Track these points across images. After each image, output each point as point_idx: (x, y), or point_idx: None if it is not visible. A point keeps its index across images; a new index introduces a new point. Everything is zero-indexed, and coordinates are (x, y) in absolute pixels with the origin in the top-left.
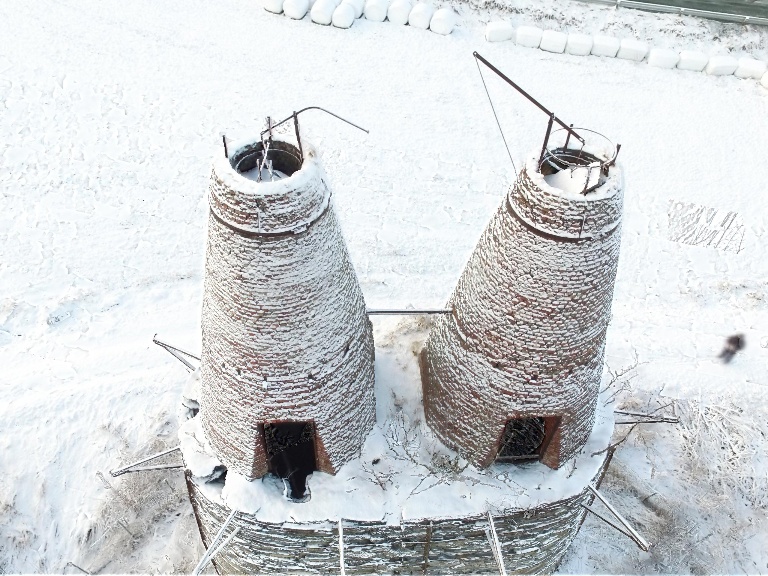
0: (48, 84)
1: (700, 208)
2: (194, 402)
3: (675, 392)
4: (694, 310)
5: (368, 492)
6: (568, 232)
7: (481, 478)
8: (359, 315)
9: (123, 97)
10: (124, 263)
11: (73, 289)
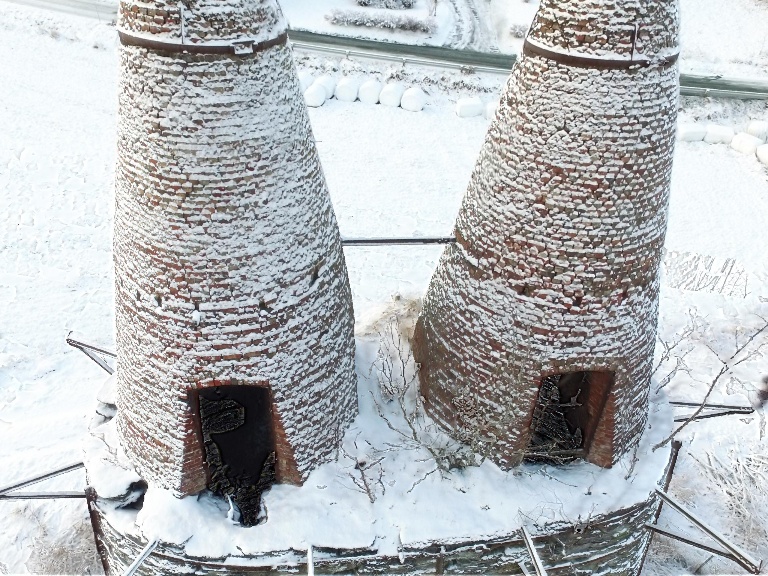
0: (4, 156)
1: (696, 256)
2: (112, 408)
3: (708, 442)
4: (710, 355)
5: (349, 506)
6: (615, 52)
7: (508, 481)
8: (331, 233)
9: (83, 167)
10: (66, 326)
11: (3, 356)
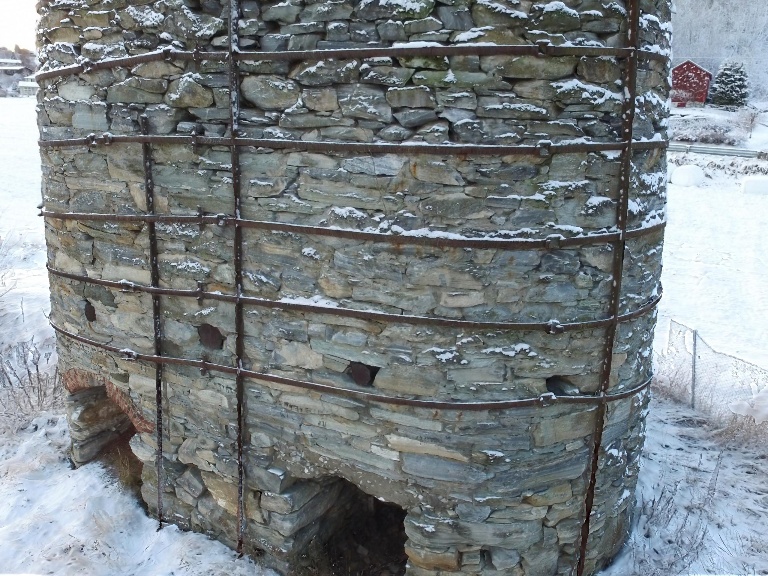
0: None
1: None
2: None
3: None
4: None
5: None
6: None
7: None
8: None
9: None
10: None
11: None
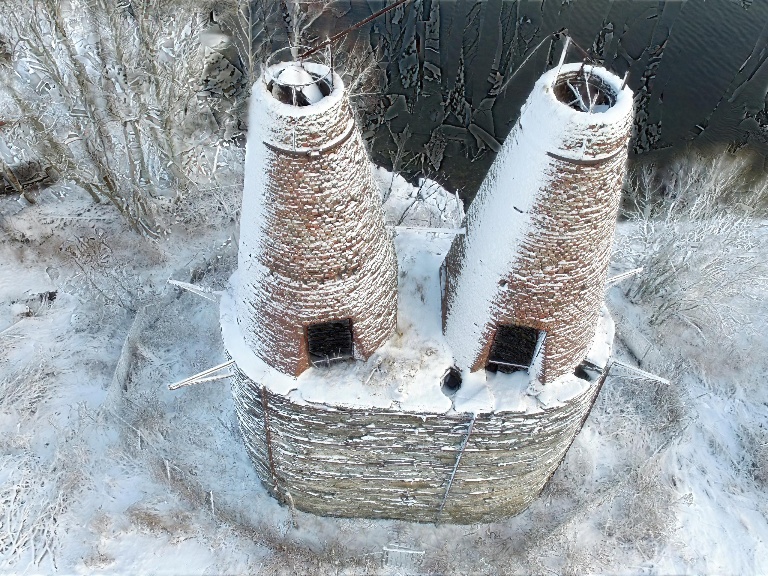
0: None
1: None
2: None
3: None
4: None
5: None
6: None
7: None
8: None
9: None
10: None
11: None
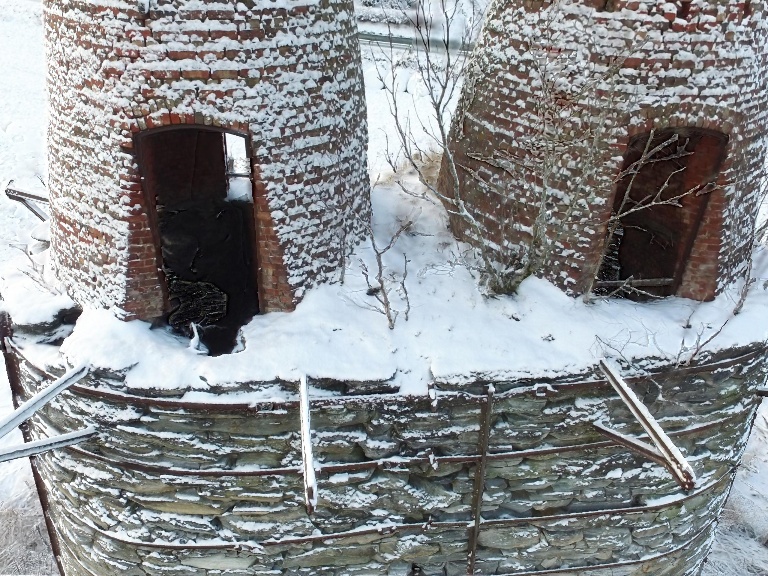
0: None
1: None
2: None
3: (763, 405)
4: None
5: (360, 332)
6: None
7: (577, 308)
8: None
9: None
10: None
11: None
